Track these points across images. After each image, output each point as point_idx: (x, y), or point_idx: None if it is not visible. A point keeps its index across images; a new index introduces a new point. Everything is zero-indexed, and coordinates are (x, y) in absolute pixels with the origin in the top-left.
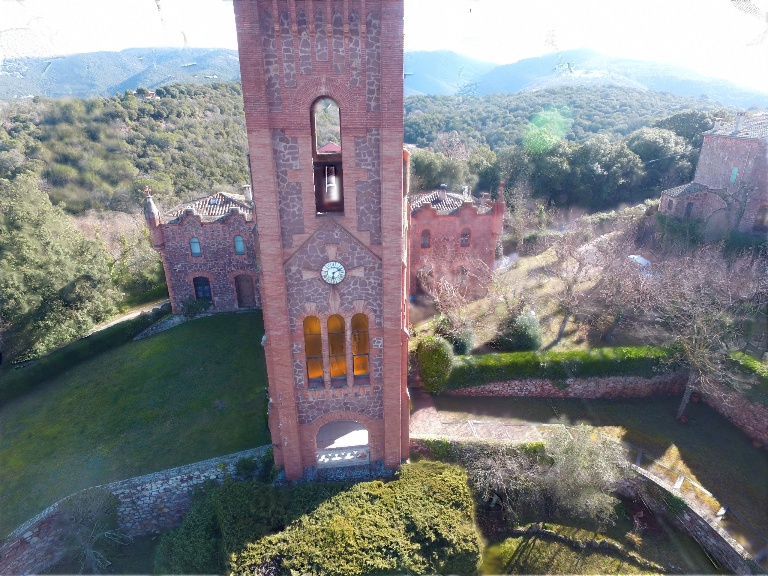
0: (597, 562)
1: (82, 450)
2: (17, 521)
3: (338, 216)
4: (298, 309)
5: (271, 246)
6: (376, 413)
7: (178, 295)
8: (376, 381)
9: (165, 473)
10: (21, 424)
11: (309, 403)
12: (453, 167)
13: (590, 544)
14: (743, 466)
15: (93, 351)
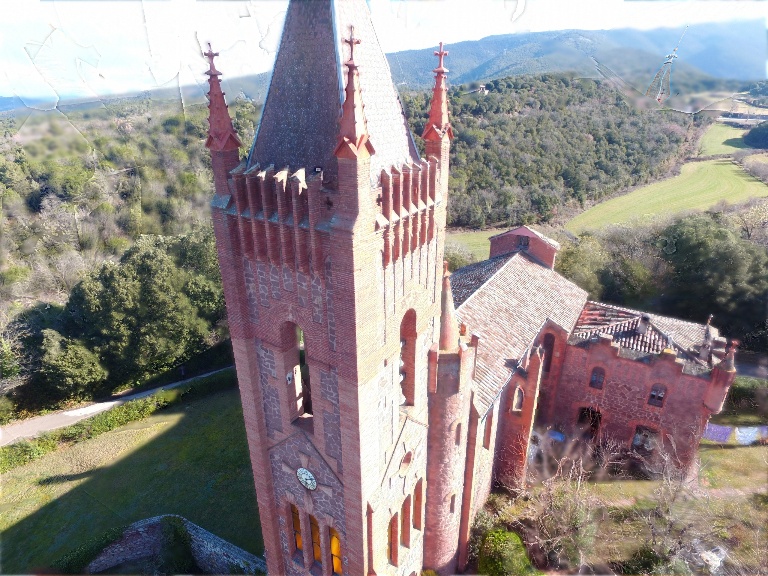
0: None
1: (212, 469)
2: (150, 510)
3: (309, 432)
4: (282, 491)
5: (253, 433)
6: None
7: None
8: None
9: (216, 540)
10: (208, 418)
11: (294, 570)
12: (732, 258)
13: None
14: None
15: None
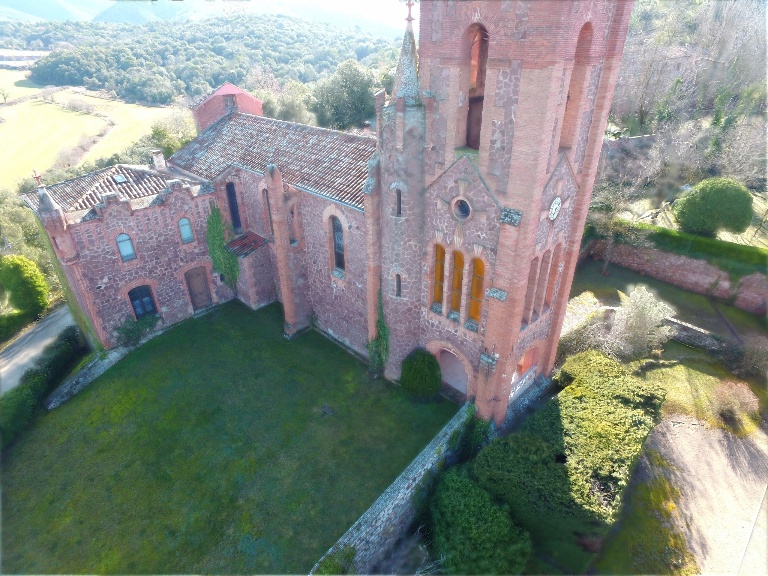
0: (652, 376)
1: (209, 548)
2: None
3: (568, 150)
4: None
5: (538, 191)
6: (545, 333)
7: (109, 322)
8: (552, 304)
9: (394, 490)
10: None
11: None
12: (296, 105)
13: (642, 368)
14: (650, 288)
15: None
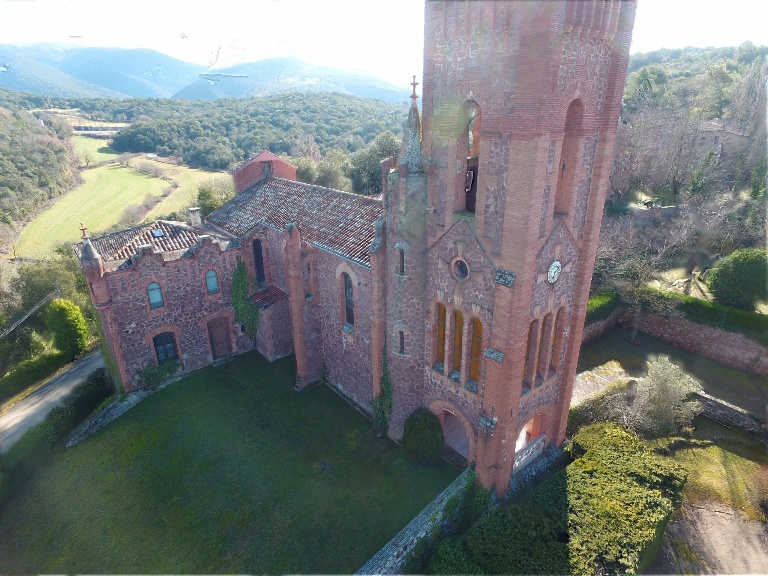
0: (682, 456)
1: None
2: None
3: (565, 216)
4: None
5: (531, 254)
6: (554, 400)
7: (132, 365)
8: (559, 369)
9: (381, 556)
10: None
11: (518, 410)
12: (333, 171)
13: (670, 446)
14: (683, 361)
15: (13, 485)
